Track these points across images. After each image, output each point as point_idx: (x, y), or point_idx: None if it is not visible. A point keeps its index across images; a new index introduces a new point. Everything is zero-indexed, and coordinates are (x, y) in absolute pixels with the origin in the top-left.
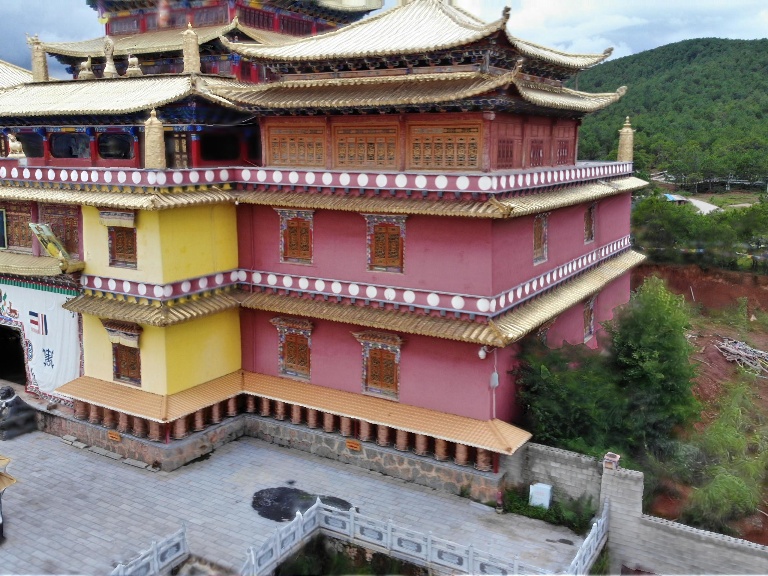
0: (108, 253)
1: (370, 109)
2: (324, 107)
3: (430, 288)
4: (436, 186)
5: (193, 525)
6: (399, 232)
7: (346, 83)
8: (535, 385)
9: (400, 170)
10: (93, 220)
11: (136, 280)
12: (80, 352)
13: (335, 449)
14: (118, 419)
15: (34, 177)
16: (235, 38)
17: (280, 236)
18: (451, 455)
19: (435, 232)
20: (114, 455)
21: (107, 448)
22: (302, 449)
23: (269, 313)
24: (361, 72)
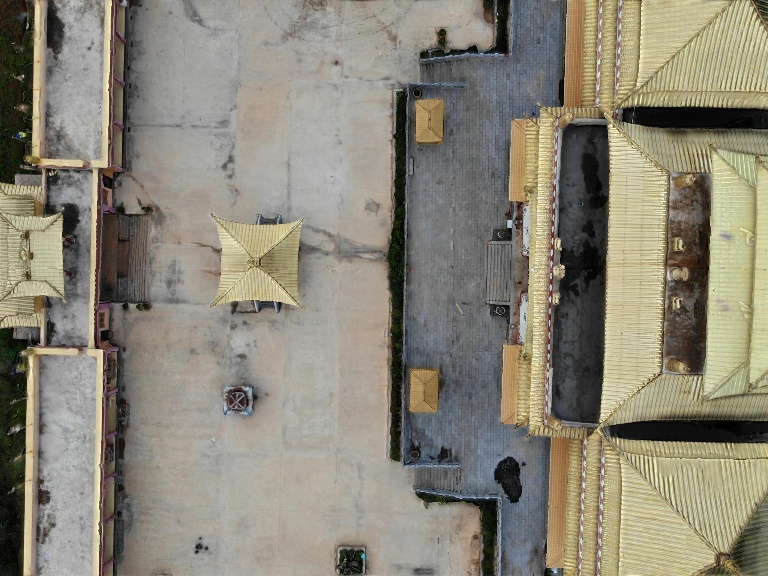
0: None
1: None
2: None
3: None
4: None
5: (476, 453)
6: None
7: None
8: None
9: None
10: None
11: None
12: None
13: None
14: None
15: (549, 319)
16: None
17: None
18: None
19: None
20: None
21: None
22: None
23: None
24: None
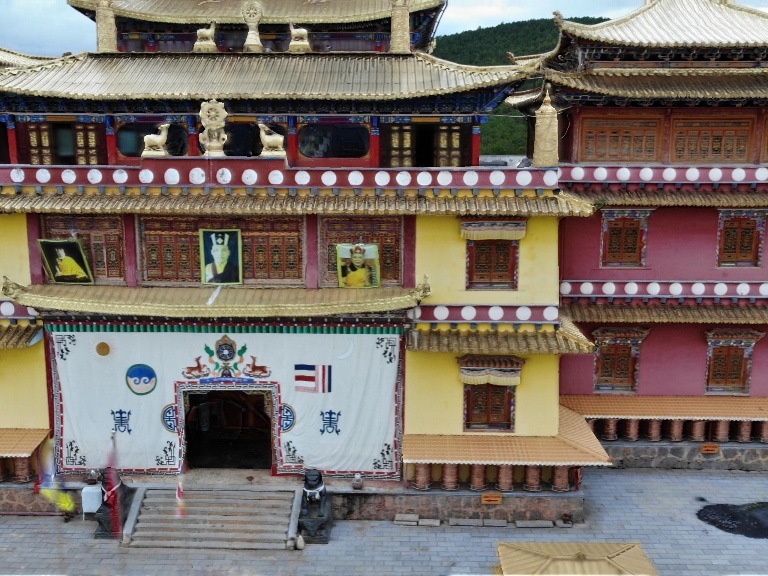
0: (464, 274)
1: (723, 101)
2: (678, 98)
3: None
4: None
5: (727, 567)
6: (755, 226)
7: (677, 73)
8: None
9: (754, 163)
10: (439, 234)
11: (514, 303)
12: (395, 406)
13: (685, 457)
14: None
15: (320, 182)
16: (432, 15)
17: (601, 239)
18: None
19: None
20: (495, 522)
21: (475, 516)
22: (640, 466)
23: (593, 325)
24: (698, 63)
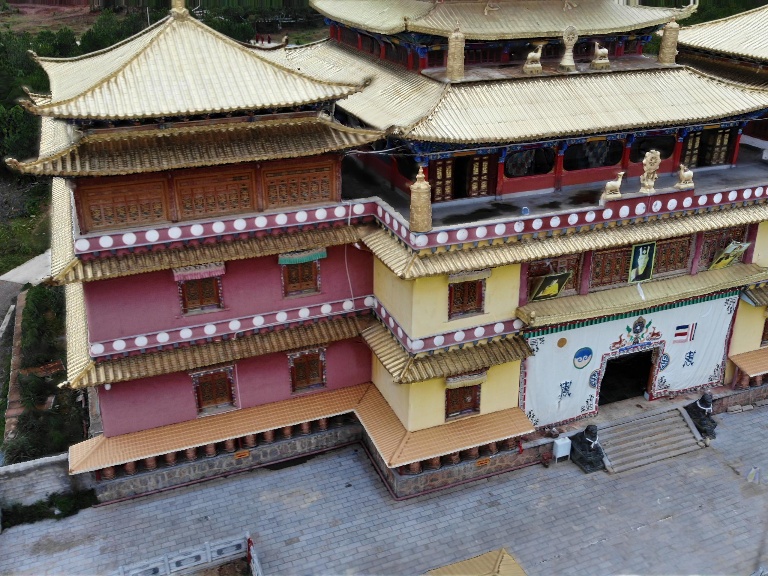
0: None
1: None
2: None
3: None
4: None
5: None
6: None
7: None
8: None
9: None
10: None
11: None
12: (725, 340)
13: None
14: None
15: (713, 202)
16: None
17: None
18: None
19: None
20: None
21: (767, 397)
22: None
23: None
24: None
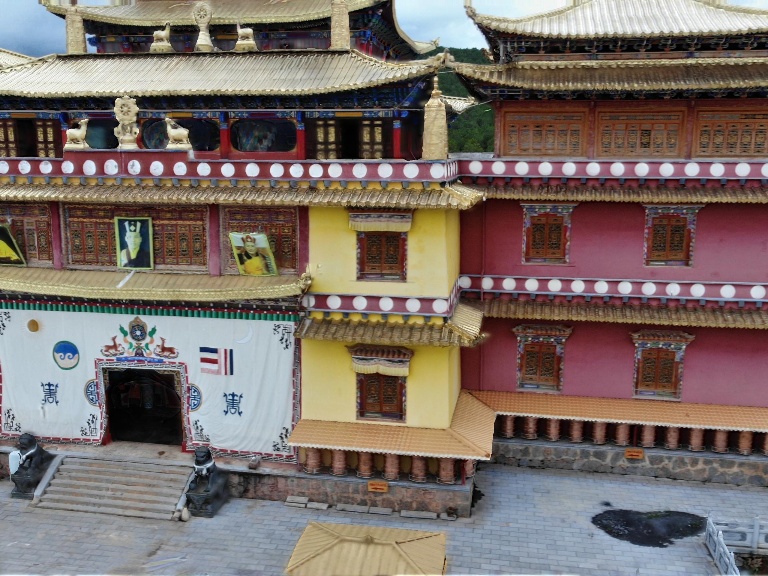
0: (355, 265)
1: (650, 94)
2: None
3: (725, 279)
4: (736, 174)
5: (592, 570)
6: (685, 223)
7: (605, 65)
8: None
9: (685, 158)
10: (330, 225)
11: (404, 295)
12: (292, 391)
13: (608, 461)
14: (380, 465)
15: (219, 174)
16: (379, 12)
17: (523, 235)
18: (757, 447)
19: (732, 221)
20: (381, 510)
21: (362, 503)
22: (561, 467)
23: (513, 321)
24: (627, 54)
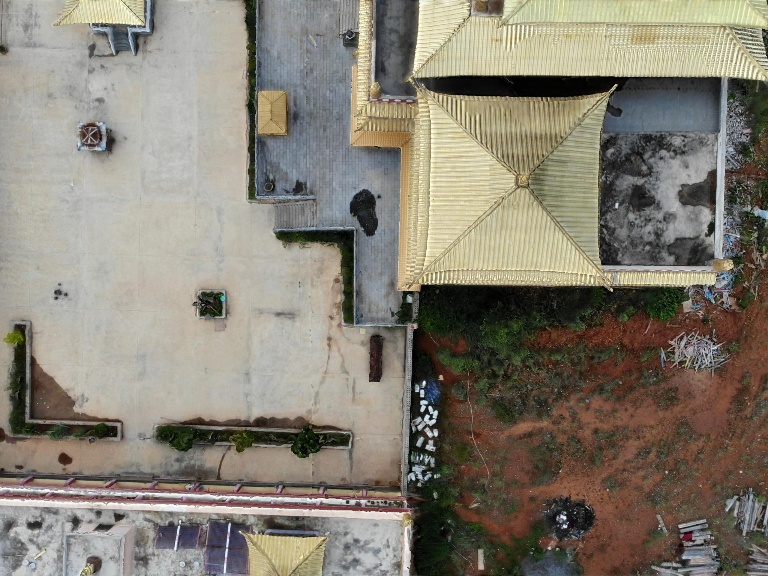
0: None
1: None
2: None
3: None
4: None
5: (331, 185)
6: None
7: None
8: (439, 286)
9: None
10: None
11: None
12: None
13: None
14: None
15: None
16: None
17: None
18: None
19: None
20: None
21: None
22: None
23: None
24: None
